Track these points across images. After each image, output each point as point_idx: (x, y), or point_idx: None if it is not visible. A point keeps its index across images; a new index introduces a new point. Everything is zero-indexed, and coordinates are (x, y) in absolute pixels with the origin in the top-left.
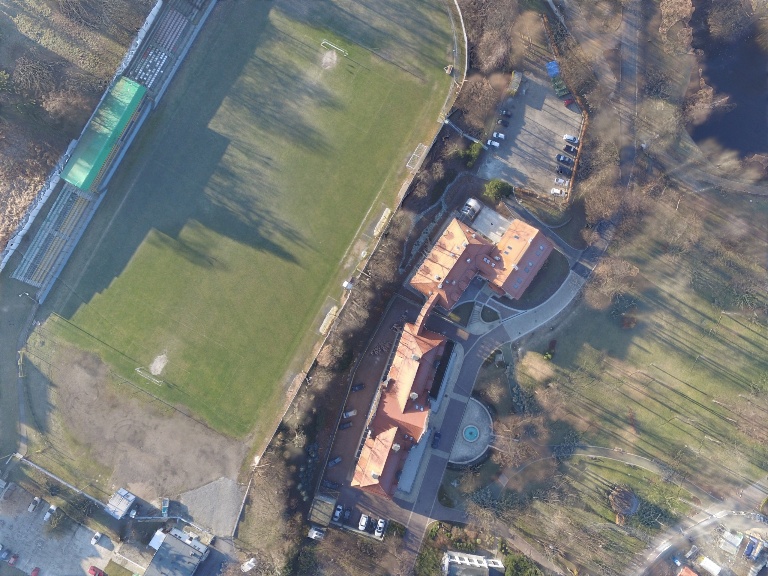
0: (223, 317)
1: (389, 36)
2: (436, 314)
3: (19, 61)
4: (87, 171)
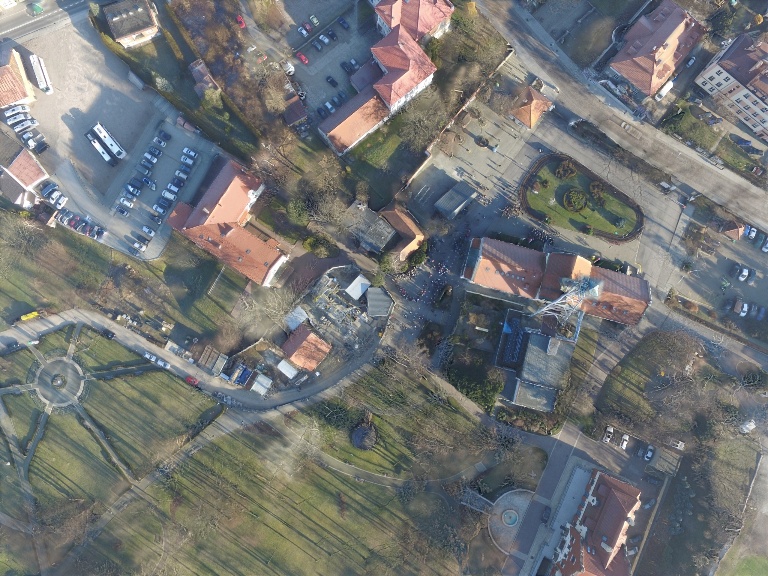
0: None
1: None
2: None
3: None
4: None
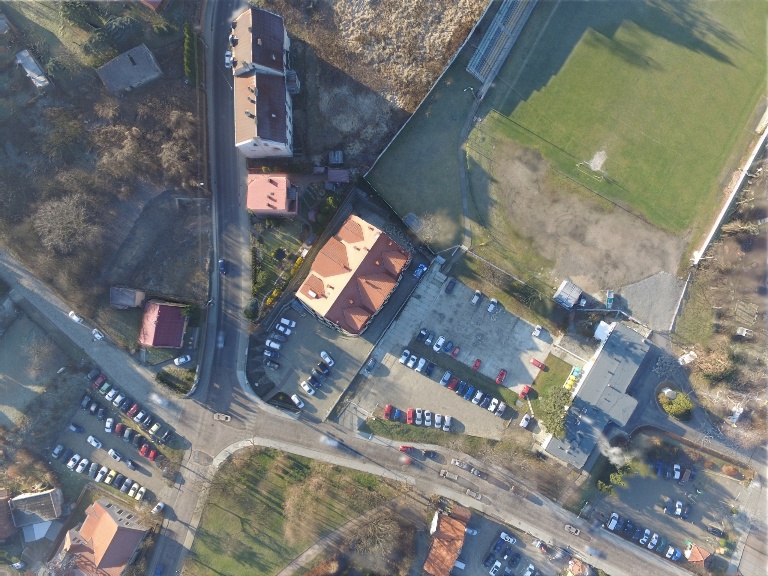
0: (660, 115)
1: None
2: None
3: None
4: None
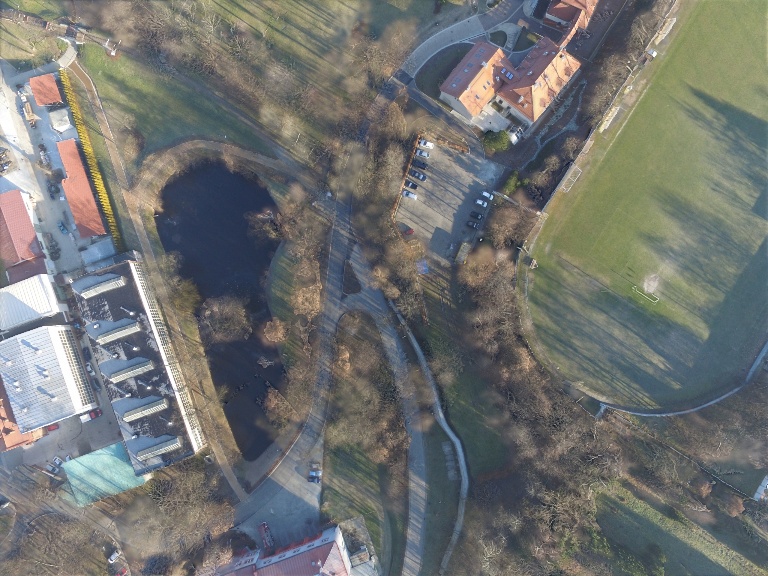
0: (763, 43)
1: (590, 303)
2: None
3: None
4: None
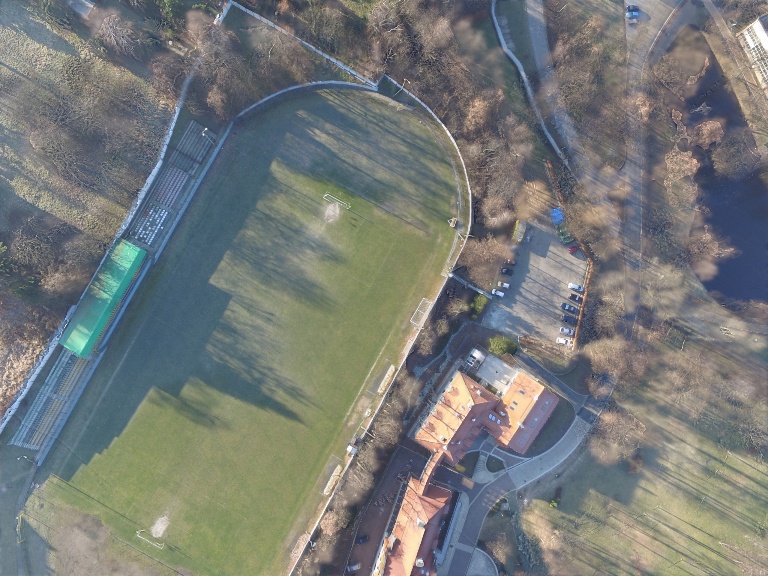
0: (225, 477)
1: (392, 188)
2: (441, 465)
3: (17, 233)
4: (86, 338)
